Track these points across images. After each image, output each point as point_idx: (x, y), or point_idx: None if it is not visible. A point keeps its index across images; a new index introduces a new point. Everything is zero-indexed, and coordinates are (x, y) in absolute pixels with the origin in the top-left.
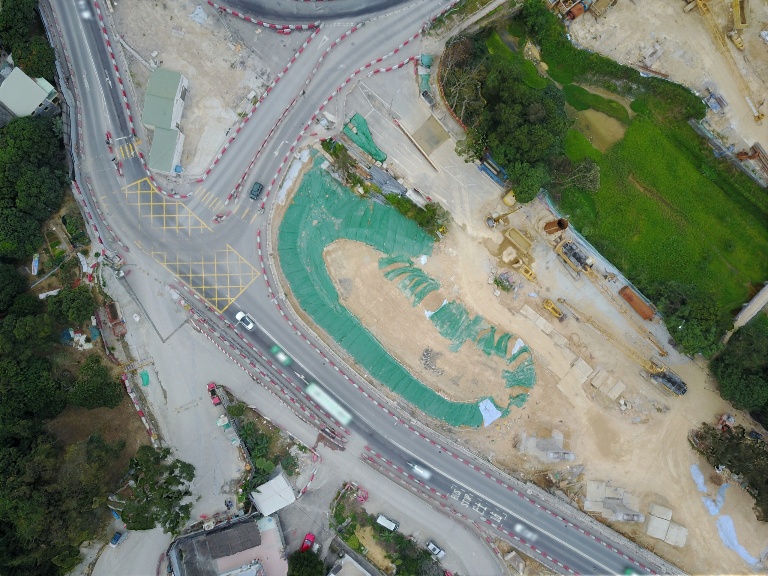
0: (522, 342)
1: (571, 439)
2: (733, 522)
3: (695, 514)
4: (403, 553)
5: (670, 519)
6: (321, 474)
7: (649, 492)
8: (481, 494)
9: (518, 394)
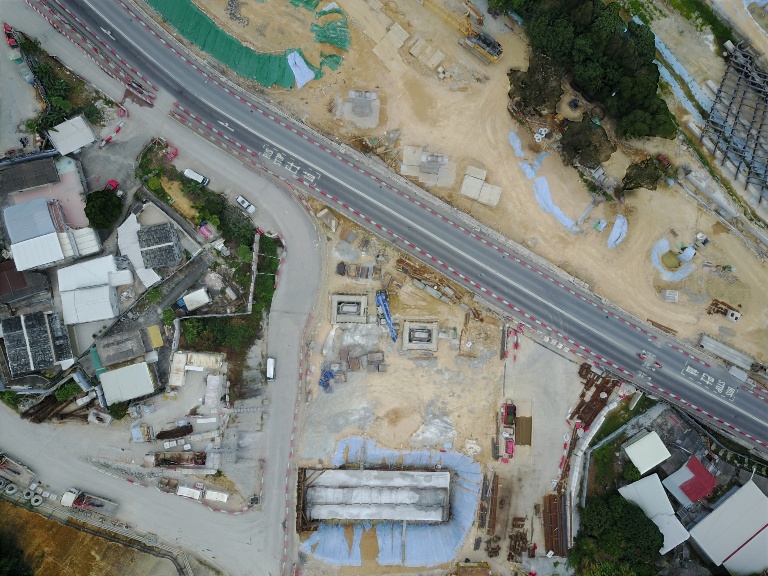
0: (337, 6)
1: (388, 105)
2: (548, 182)
3: (512, 178)
4: (210, 202)
5: (485, 180)
6: (128, 129)
7: (466, 157)
8: (294, 153)
9: (331, 54)
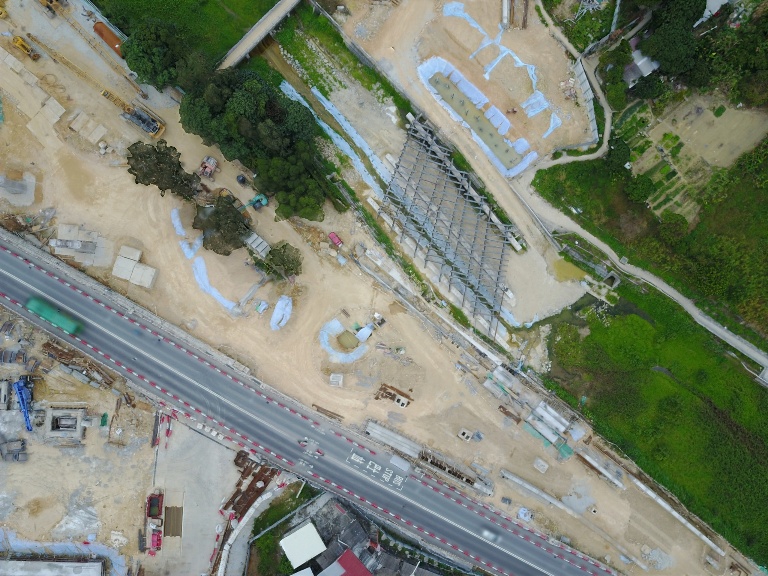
0: None
1: (43, 181)
2: (205, 263)
3: (171, 257)
4: None
5: (140, 261)
6: None
7: (124, 236)
8: None
9: None
